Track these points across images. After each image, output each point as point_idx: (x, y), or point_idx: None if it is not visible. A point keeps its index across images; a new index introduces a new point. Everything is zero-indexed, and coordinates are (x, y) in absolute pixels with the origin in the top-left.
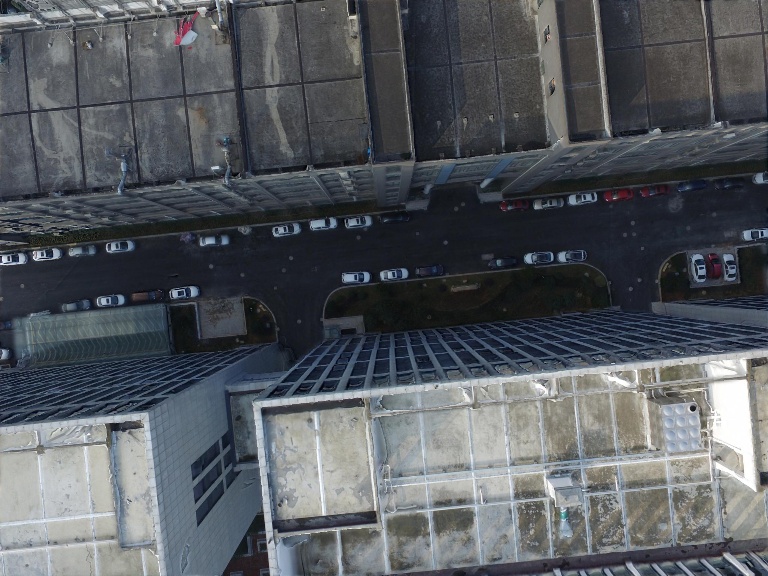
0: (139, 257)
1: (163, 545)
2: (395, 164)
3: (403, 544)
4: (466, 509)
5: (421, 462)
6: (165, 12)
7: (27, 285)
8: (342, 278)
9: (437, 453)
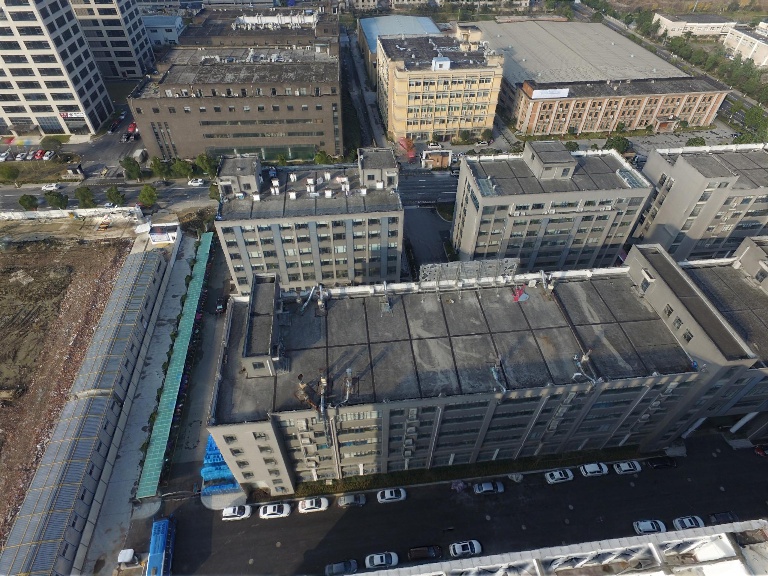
0: (410, 508)
1: None
2: (741, 363)
3: None
4: None
5: None
6: (502, 285)
7: (284, 543)
8: (637, 527)
9: None
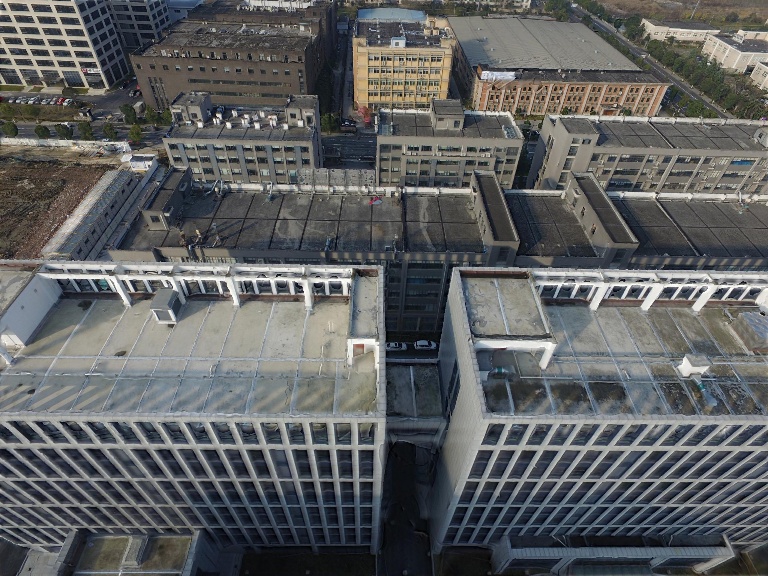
0: None
1: (384, 335)
2: (507, 244)
3: (568, 406)
4: (616, 384)
5: (569, 348)
6: (366, 194)
7: None
8: None
9: (580, 344)
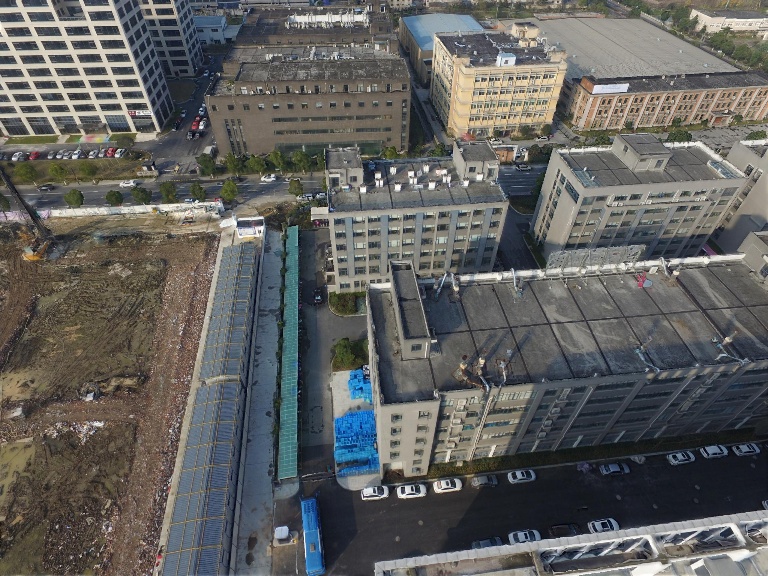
0: (541, 488)
1: None
2: None
3: None
4: None
5: None
6: (623, 271)
7: (425, 522)
8: (767, 506)
9: None
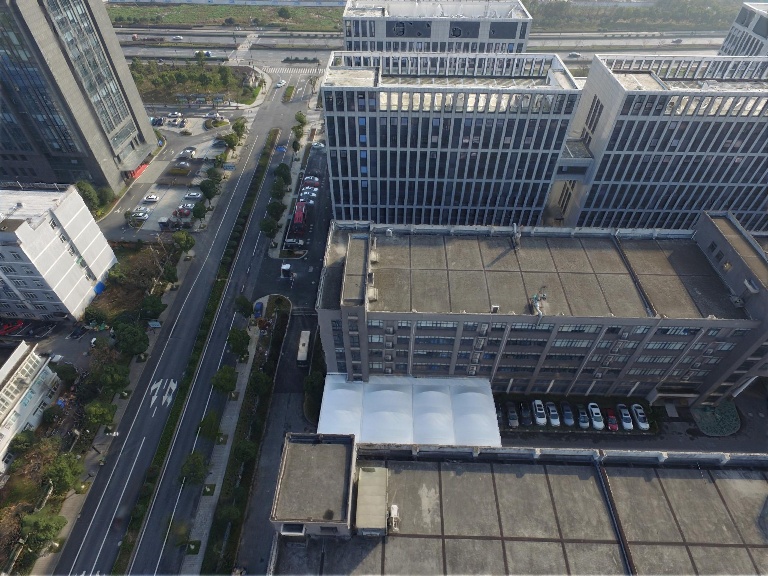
0: None
1: None
2: None
3: (762, 87)
4: None
5: None
6: None
7: None
8: None
9: None
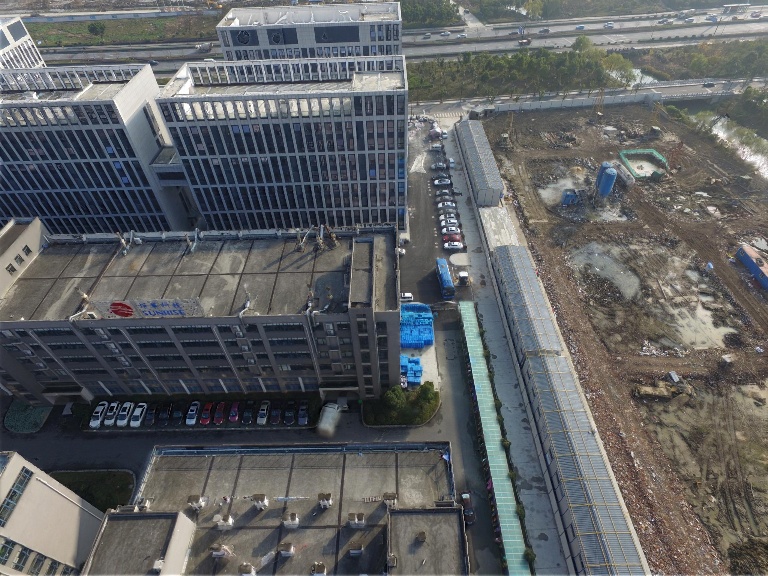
0: None
1: None
2: (27, 221)
3: None
4: None
5: None
6: None
7: None
8: None
9: None
